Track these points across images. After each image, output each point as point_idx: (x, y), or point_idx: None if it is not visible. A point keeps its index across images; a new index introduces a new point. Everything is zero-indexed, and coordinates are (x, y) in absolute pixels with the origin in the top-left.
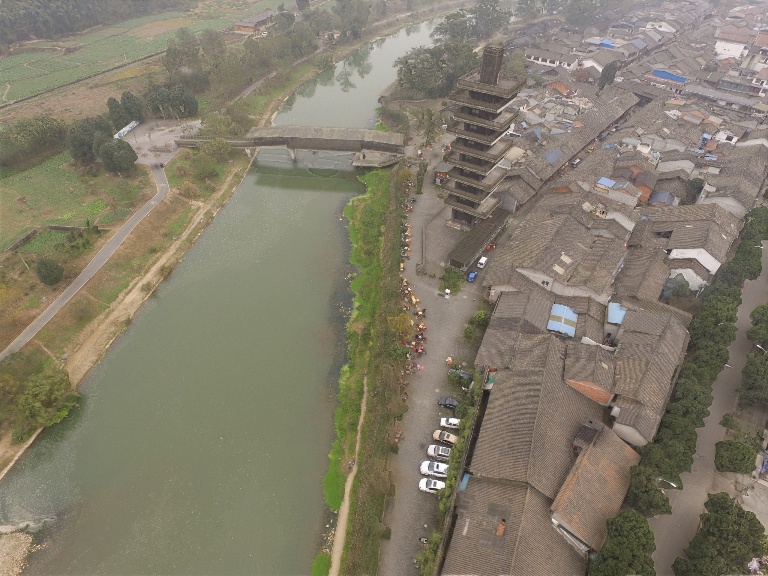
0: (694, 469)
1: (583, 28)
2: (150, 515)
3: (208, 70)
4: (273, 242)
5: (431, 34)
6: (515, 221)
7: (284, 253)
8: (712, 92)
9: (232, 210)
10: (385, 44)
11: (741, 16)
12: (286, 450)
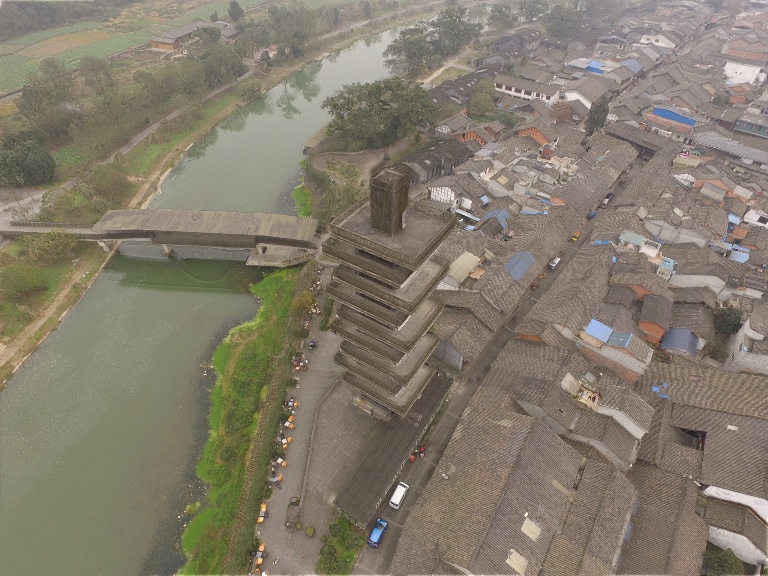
0: None
1: (566, 42)
2: None
3: None
4: (86, 430)
5: (384, 53)
6: (461, 387)
7: (97, 454)
8: (734, 147)
9: (46, 358)
10: (340, 58)
11: (749, 26)
12: None
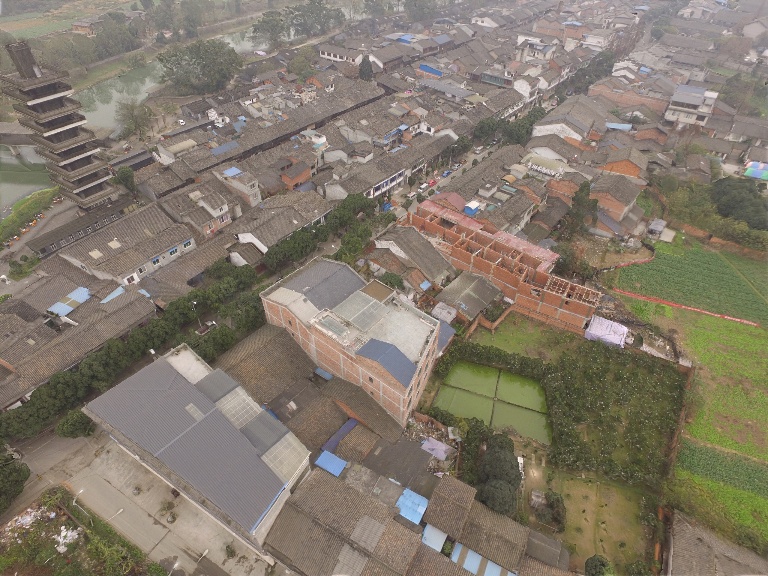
0: None
1: None
2: None
3: None
4: None
5: (253, 32)
6: None
7: None
8: (440, 85)
9: None
10: None
11: (572, 11)
12: None
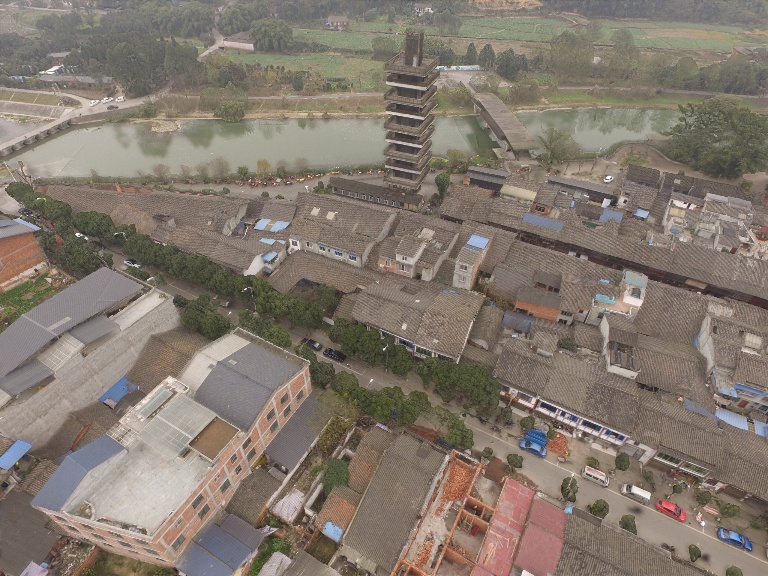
0: None
1: None
2: (178, 147)
3: (607, 66)
4: (367, 139)
5: None
6: None
7: (358, 145)
8: None
9: None
10: None
11: None
12: None
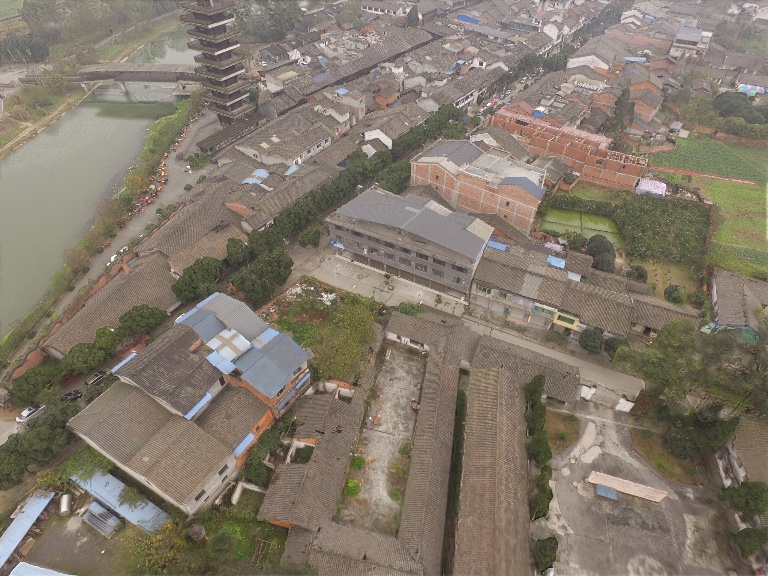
0: (300, 253)
1: None
2: None
3: None
4: (80, 148)
5: None
6: None
7: (87, 155)
8: (483, 29)
9: (55, 128)
10: None
11: None
12: (35, 263)
